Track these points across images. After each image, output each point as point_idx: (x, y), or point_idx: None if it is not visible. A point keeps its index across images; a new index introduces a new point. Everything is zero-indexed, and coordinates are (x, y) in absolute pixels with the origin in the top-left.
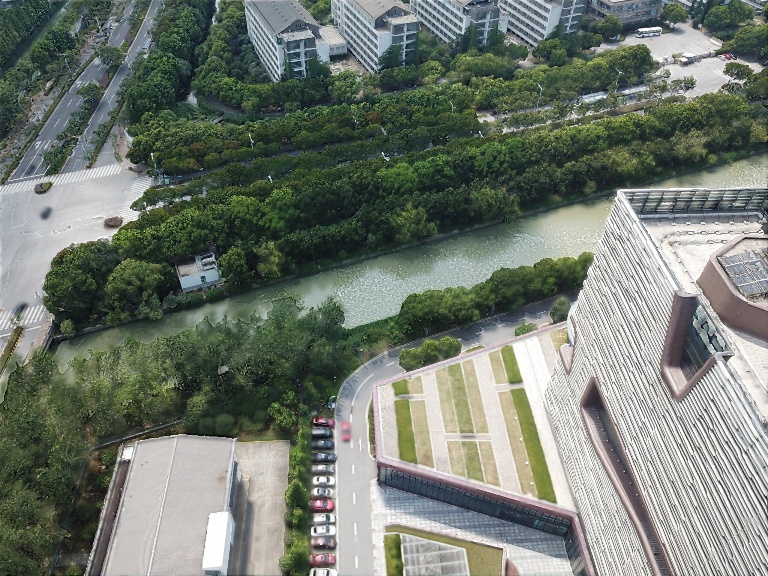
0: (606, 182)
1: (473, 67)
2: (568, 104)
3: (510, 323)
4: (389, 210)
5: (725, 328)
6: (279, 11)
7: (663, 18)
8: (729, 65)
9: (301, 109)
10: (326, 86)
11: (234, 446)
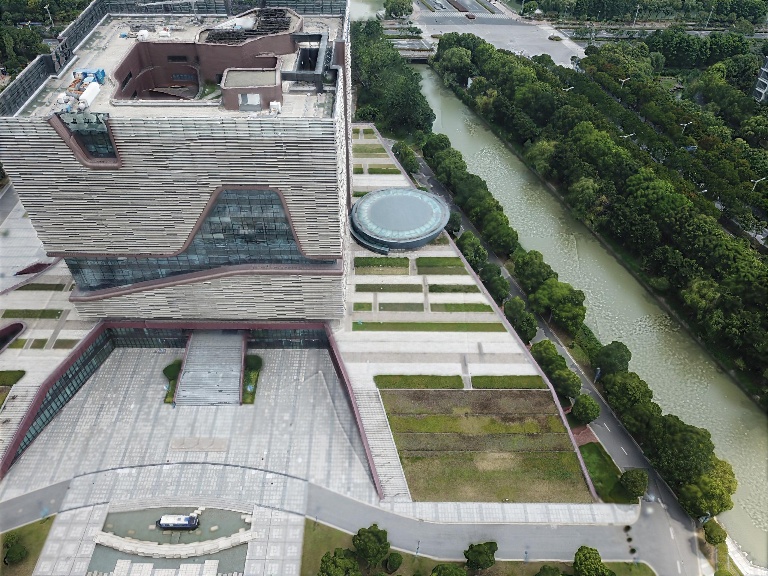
0: None
1: None
2: None
3: (449, 210)
4: None
5: None
6: None
7: None
8: None
9: None
10: None
11: None
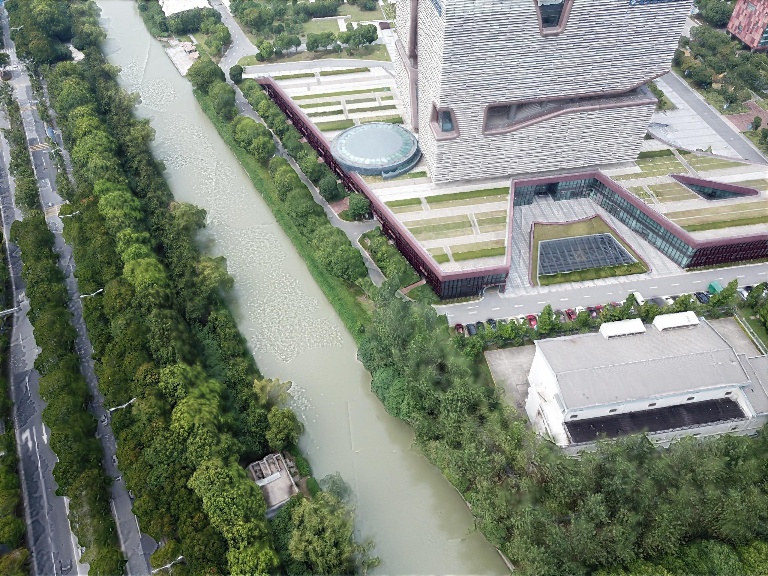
0: None
1: None
2: None
3: None
4: None
5: None
6: None
7: None
8: None
9: None
10: None
11: (542, 340)
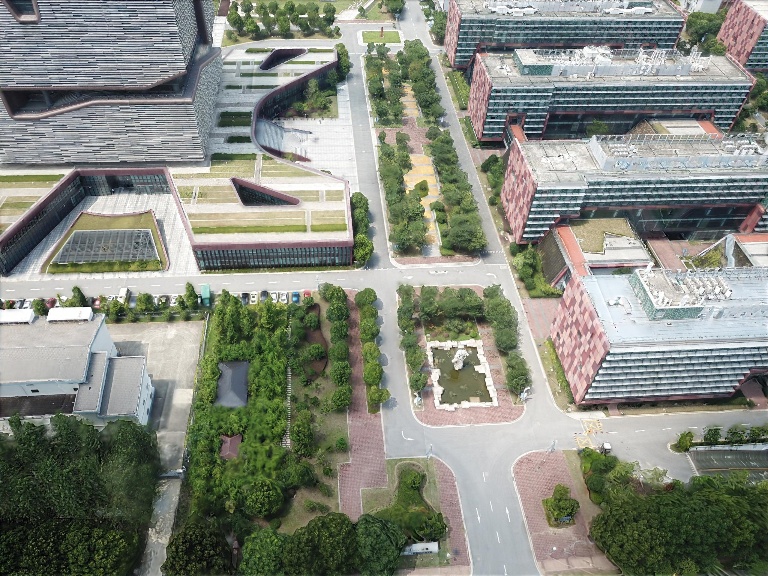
0: None
1: None
2: None
3: None
4: None
5: None
6: None
7: None
8: None
9: None
10: None
11: None
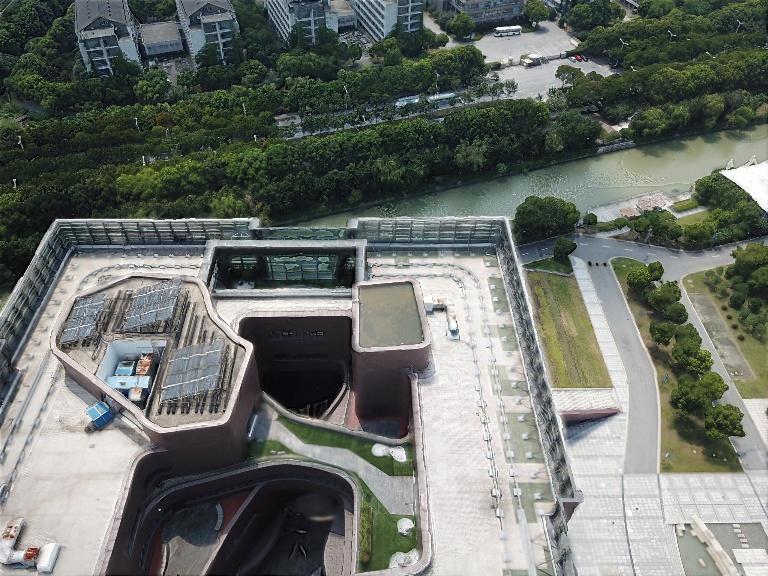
0: (382, 190)
1: (291, 67)
2: (384, 107)
3: None
4: (123, 217)
5: (58, 375)
6: (88, 8)
7: (526, 16)
8: (560, 68)
9: (104, 108)
10: (132, 85)
11: None
